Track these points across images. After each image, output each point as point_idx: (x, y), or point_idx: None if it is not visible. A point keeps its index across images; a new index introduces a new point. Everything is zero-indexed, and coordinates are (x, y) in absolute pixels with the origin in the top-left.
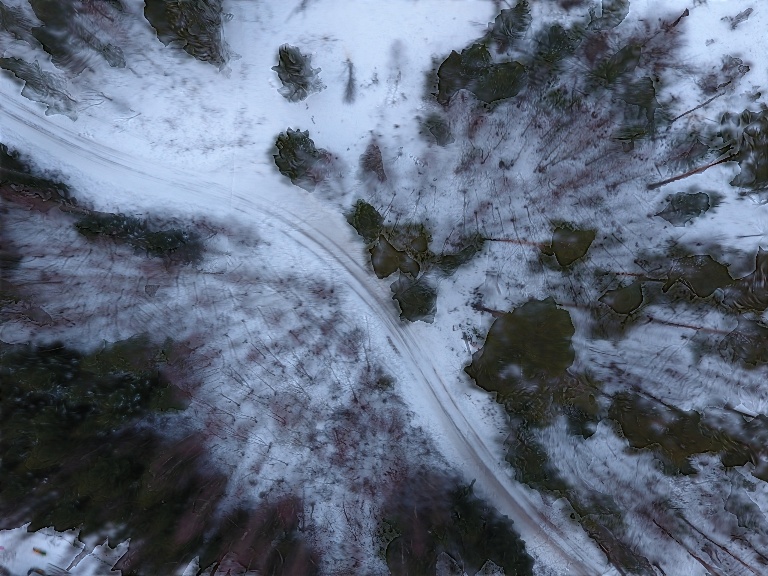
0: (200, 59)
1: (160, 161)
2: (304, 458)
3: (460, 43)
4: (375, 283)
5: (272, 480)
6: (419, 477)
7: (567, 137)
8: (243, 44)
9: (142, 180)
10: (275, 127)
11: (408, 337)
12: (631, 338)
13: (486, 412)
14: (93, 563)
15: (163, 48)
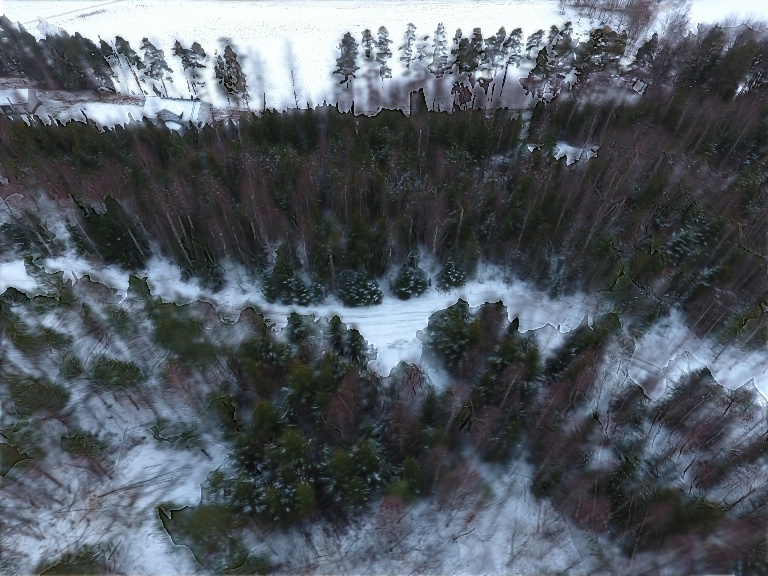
0: None
1: (5, 289)
2: None
3: None
4: None
5: None
6: None
7: None
8: None
9: (26, 277)
10: None
11: None
12: None
13: None
14: None
15: None
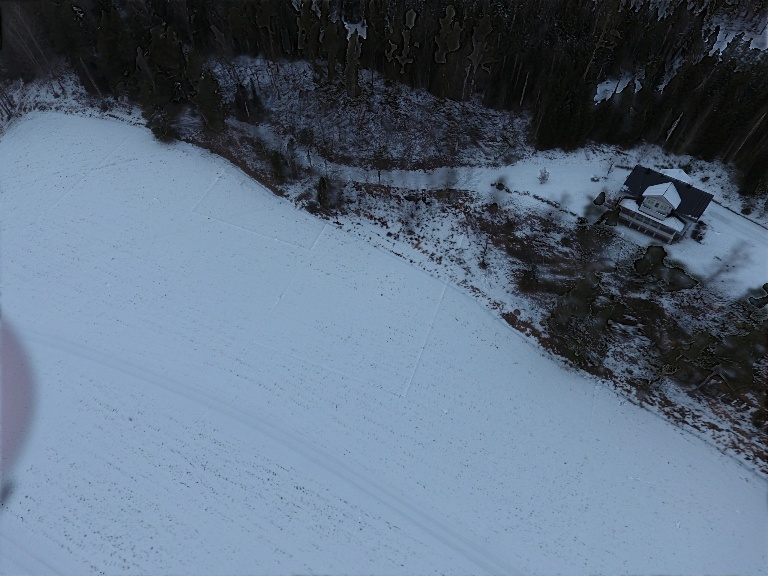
0: None
1: None
2: None
3: None
4: None
5: None
6: None
7: None
8: None
9: None
10: None
11: None
12: None
13: None
14: None
15: (733, 29)
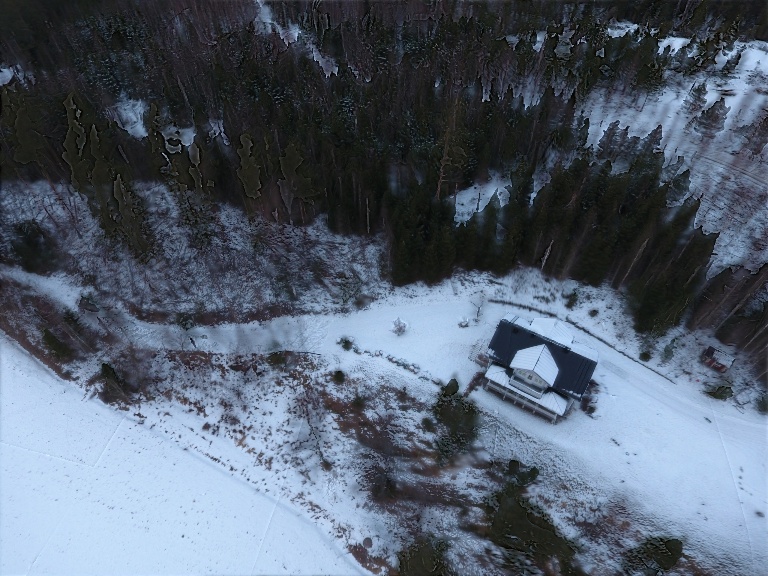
0: (652, 93)
1: None
2: (753, 255)
3: (764, 106)
4: (761, 178)
5: (734, 266)
6: None
7: None
8: (650, 107)
9: None
10: (676, 128)
11: None
12: None
13: None
14: (582, 336)
15: None
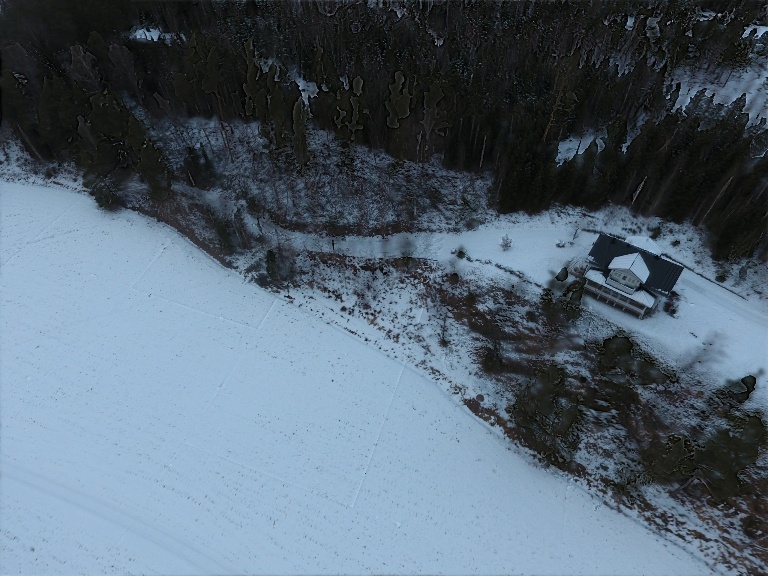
0: (736, 70)
1: None
2: None
3: None
4: None
5: None
6: None
7: None
8: (732, 84)
9: None
10: (757, 102)
11: None
12: None
13: None
14: None
15: None
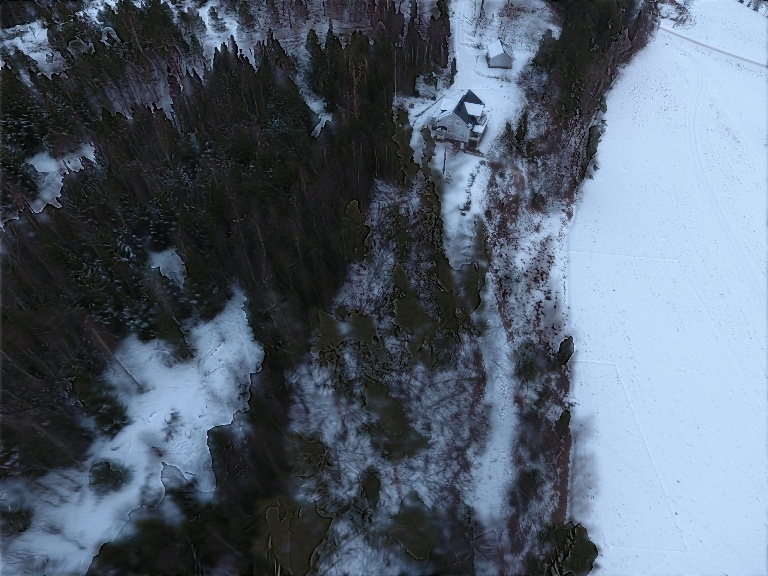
0: None
1: None
2: None
3: None
4: None
5: None
6: (371, 36)
7: (254, 2)
8: None
9: None
10: None
11: (317, 30)
12: (321, 1)
13: (346, 23)
14: (426, 114)
15: None
